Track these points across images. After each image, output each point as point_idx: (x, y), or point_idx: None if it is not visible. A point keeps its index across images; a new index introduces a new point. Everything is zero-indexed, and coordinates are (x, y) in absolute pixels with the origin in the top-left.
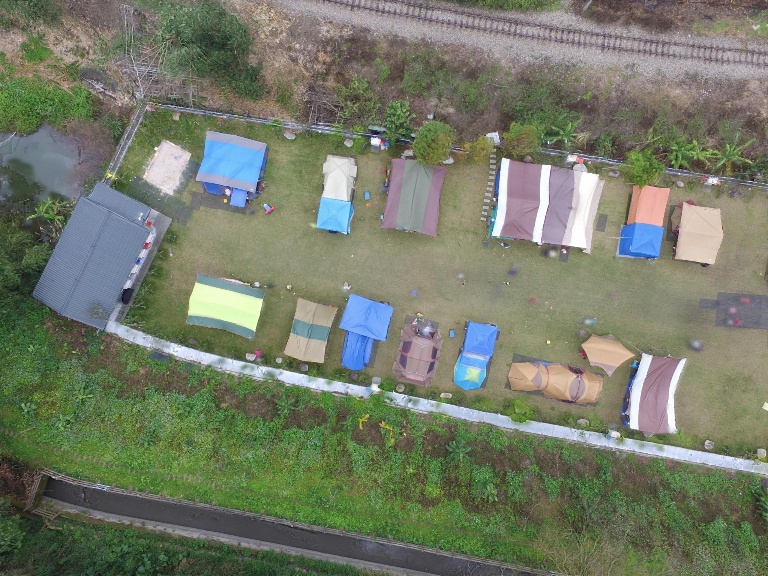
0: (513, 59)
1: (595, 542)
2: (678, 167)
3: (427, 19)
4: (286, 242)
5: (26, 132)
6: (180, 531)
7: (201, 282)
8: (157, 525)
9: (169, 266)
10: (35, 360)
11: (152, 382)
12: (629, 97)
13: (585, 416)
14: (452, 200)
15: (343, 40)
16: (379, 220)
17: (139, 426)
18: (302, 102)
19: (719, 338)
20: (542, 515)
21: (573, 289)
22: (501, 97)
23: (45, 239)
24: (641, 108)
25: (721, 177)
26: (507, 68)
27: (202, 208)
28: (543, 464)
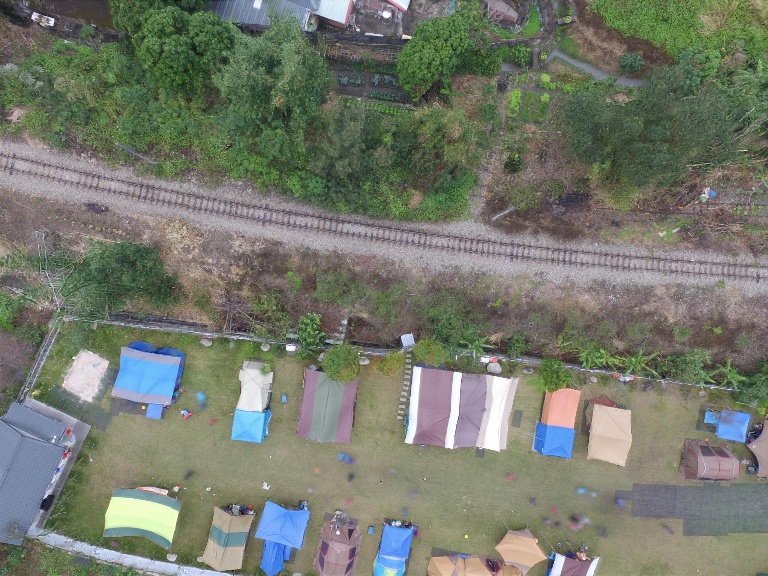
0: (424, 268)
1: None
2: (589, 368)
3: (337, 233)
4: (205, 445)
5: None
6: None
7: (117, 495)
8: None
9: (89, 471)
10: None
11: None
12: (539, 303)
13: None
14: (369, 400)
15: (255, 255)
16: (297, 421)
17: None
18: (220, 304)
19: (635, 528)
20: None
21: (490, 484)
22: (413, 304)
23: None
24: (551, 314)
25: (632, 376)
26: (418, 277)
27: (121, 414)
28: None
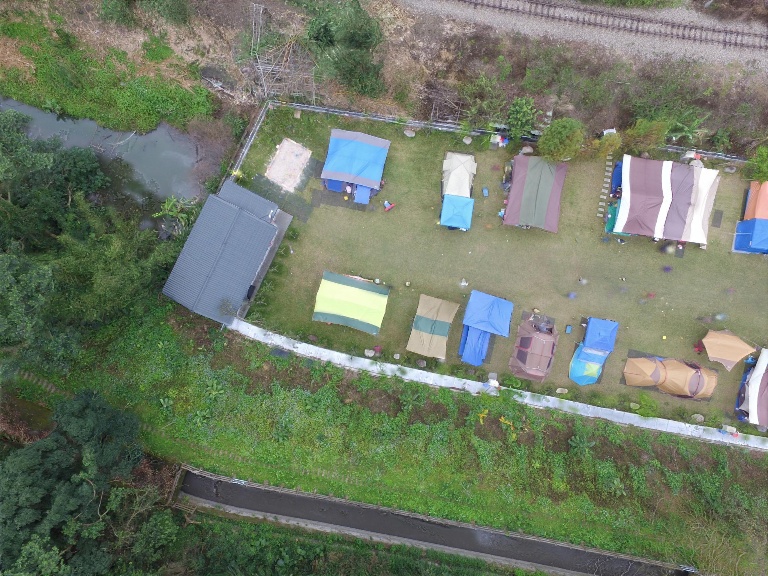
0: (634, 56)
1: (722, 536)
2: None
3: (550, 16)
4: (405, 239)
5: (146, 131)
6: (312, 525)
7: (326, 279)
8: (289, 519)
9: (289, 263)
10: (165, 356)
11: (277, 378)
12: (749, 93)
13: (699, 411)
14: (569, 196)
15: (467, 38)
16: (497, 217)
17: (271, 421)
18: (419, 100)
19: None
20: (668, 509)
21: (688, 285)
22: (621, 94)
23: (163, 237)
24: (761, 104)
25: None
26: (628, 65)
27: (322, 205)
28: (662, 459)
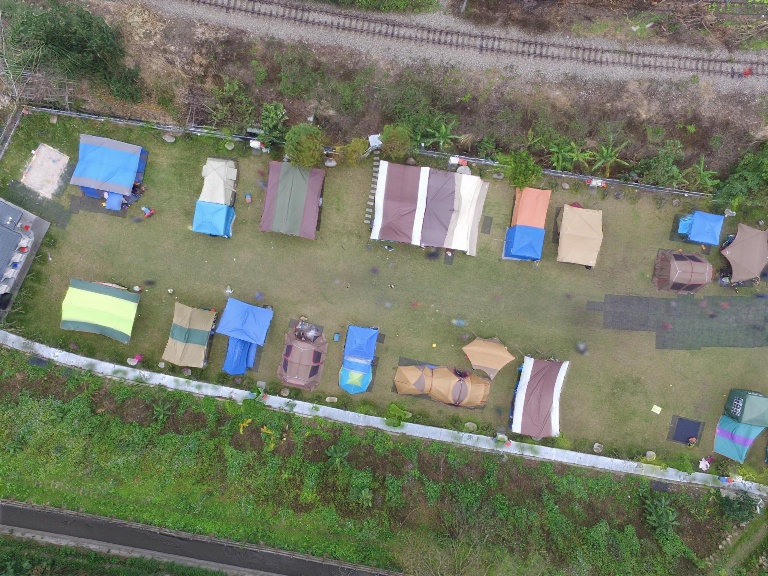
0: (391, 61)
1: (470, 547)
2: (560, 169)
3: (303, 21)
4: (167, 246)
5: None
6: (49, 538)
7: (75, 286)
8: (26, 532)
9: (48, 270)
10: None
11: (27, 388)
12: (509, 99)
13: (473, 419)
14: (335, 203)
15: (218, 42)
16: None
17: (8, 432)
18: (184, 104)
19: (607, 340)
20: (419, 520)
21: (459, 292)
22: (380, 99)
23: None
24: (521, 110)
25: (604, 179)
26: (385, 70)
27: (81, 212)
28: (426, 468)
